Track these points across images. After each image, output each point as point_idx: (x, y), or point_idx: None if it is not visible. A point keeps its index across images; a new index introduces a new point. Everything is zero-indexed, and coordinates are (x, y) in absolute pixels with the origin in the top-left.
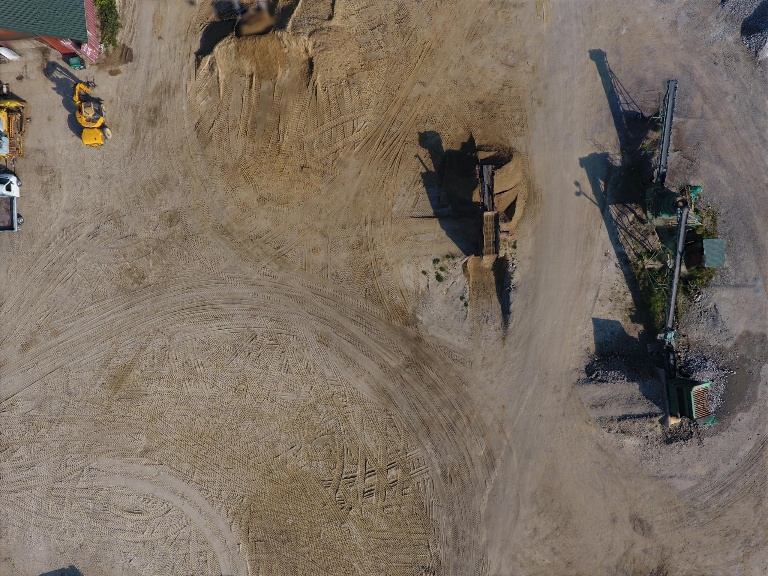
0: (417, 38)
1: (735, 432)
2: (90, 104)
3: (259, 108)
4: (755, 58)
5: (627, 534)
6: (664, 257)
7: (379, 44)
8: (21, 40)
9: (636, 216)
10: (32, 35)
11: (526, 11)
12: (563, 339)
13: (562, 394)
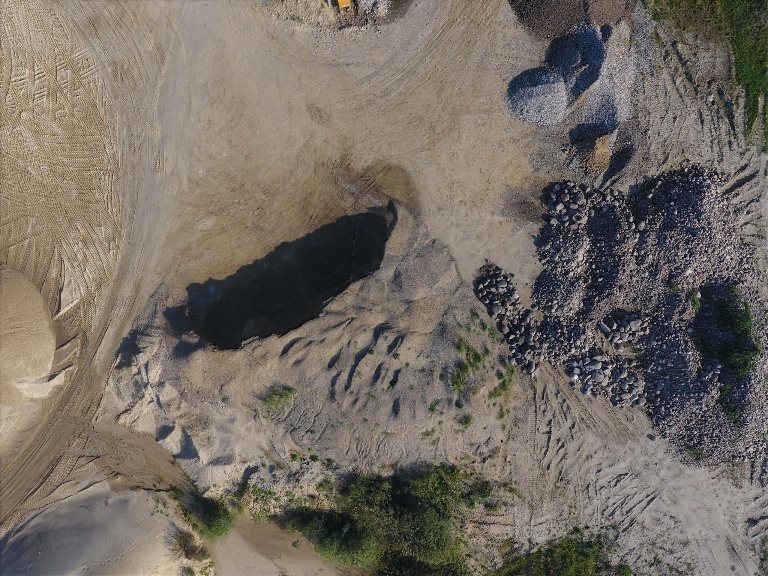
0: None
1: (412, 17)
2: None
3: None
4: None
5: (305, 124)
6: None
7: None
8: None
9: None
10: None
11: None
12: None
13: None
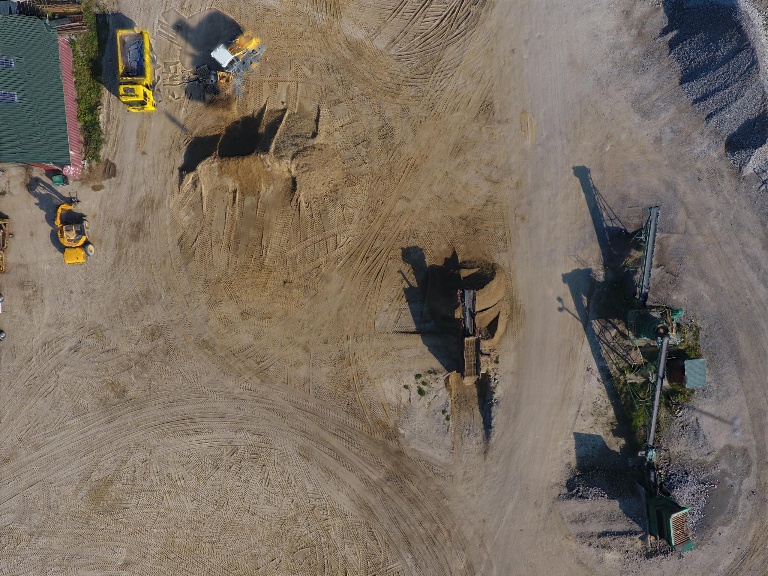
0: (401, 154)
1: (715, 546)
2: (72, 228)
3: (242, 223)
4: (739, 174)
5: None
6: (646, 373)
7: (363, 160)
8: (3, 163)
9: (618, 331)
10: (14, 161)
11: (510, 127)
12: (544, 454)
13: (543, 509)
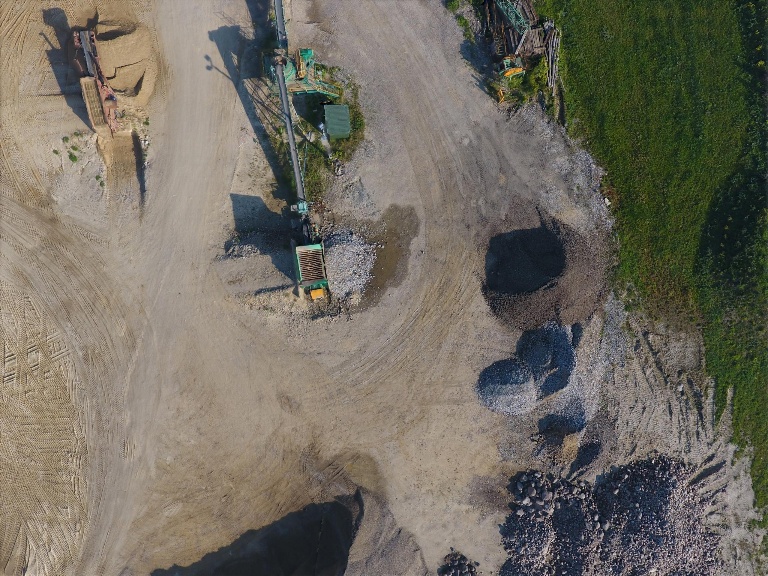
0: None
1: (385, 307)
2: None
3: None
4: None
5: (275, 412)
6: (299, 129)
7: None
8: None
9: None
10: None
11: None
12: (200, 215)
13: (200, 271)
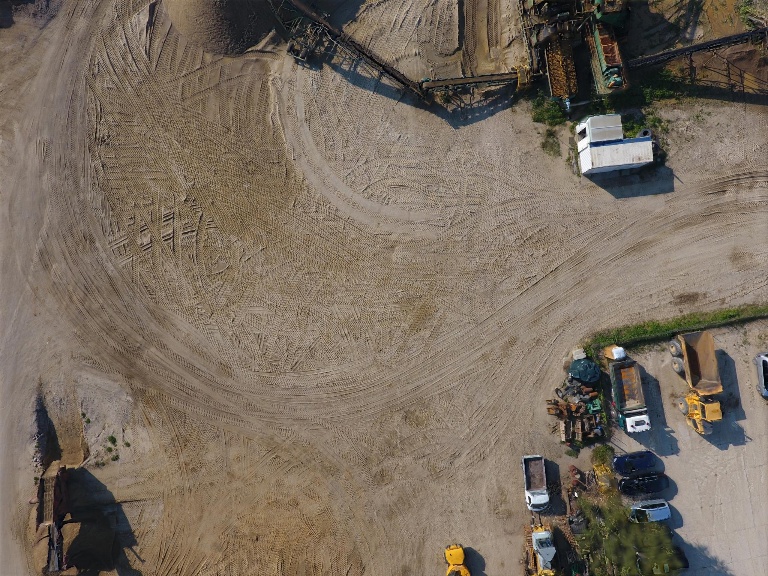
0: None
1: None
2: None
3: None
4: None
5: None
6: None
7: None
8: None
9: None
10: None
11: None
12: None
13: None
